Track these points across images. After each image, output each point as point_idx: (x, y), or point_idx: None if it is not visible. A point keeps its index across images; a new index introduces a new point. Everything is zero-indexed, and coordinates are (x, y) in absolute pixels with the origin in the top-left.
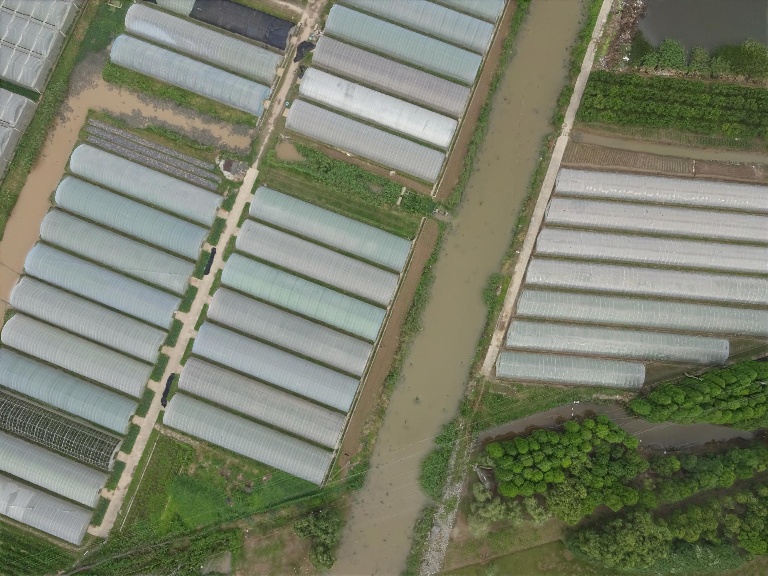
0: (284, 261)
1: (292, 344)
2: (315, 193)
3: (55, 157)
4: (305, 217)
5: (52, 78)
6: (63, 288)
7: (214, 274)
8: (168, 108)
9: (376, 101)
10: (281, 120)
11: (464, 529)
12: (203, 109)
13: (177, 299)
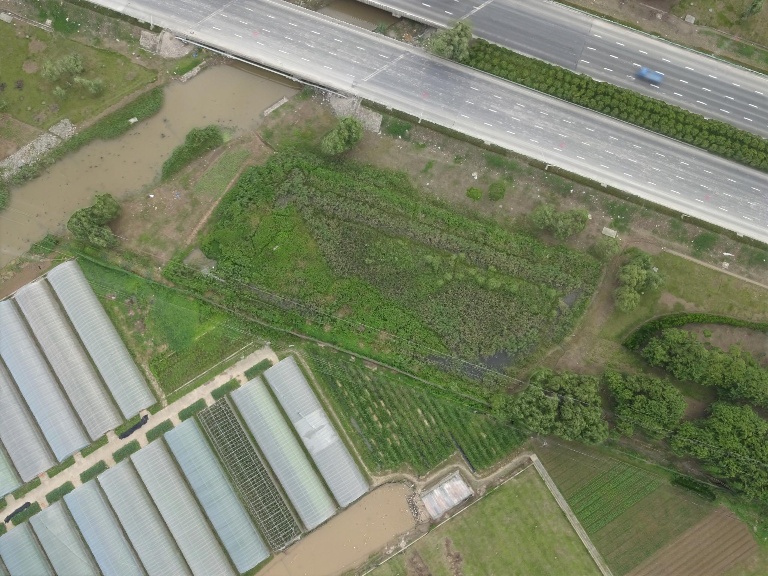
0: None
1: (2, 387)
2: None
3: None
4: None
5: None
6: None
7: (23, 498)
8: None
9: None
10: None
11: (3, 149)
12: None
13: None
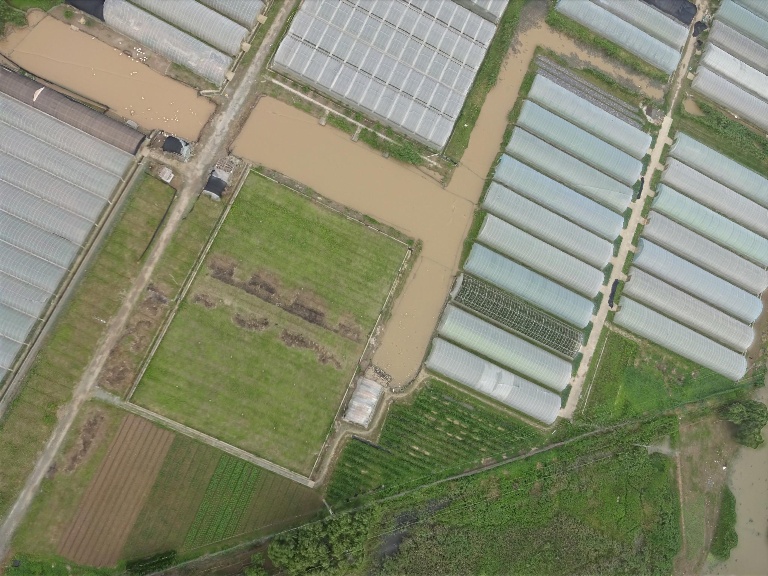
0: (702, 194)
1: (713, 262)
2: (714, 144)
3: (510, 82)
4: (718, 160)
5: (507, 13)
6: (525, 196)
7: (644, 199)
8: (599, 56)
9: (762, 77)
10: (686, 81)
11: None
12: (629, 62)
13: (621, 216)
